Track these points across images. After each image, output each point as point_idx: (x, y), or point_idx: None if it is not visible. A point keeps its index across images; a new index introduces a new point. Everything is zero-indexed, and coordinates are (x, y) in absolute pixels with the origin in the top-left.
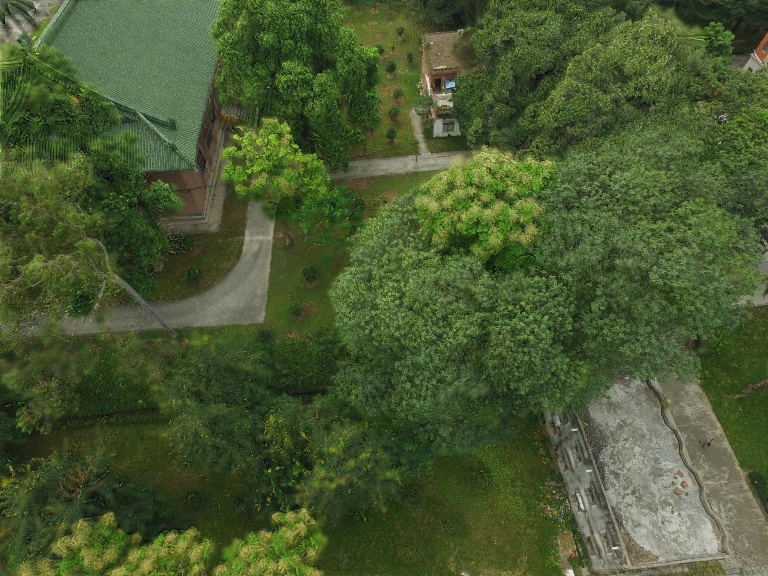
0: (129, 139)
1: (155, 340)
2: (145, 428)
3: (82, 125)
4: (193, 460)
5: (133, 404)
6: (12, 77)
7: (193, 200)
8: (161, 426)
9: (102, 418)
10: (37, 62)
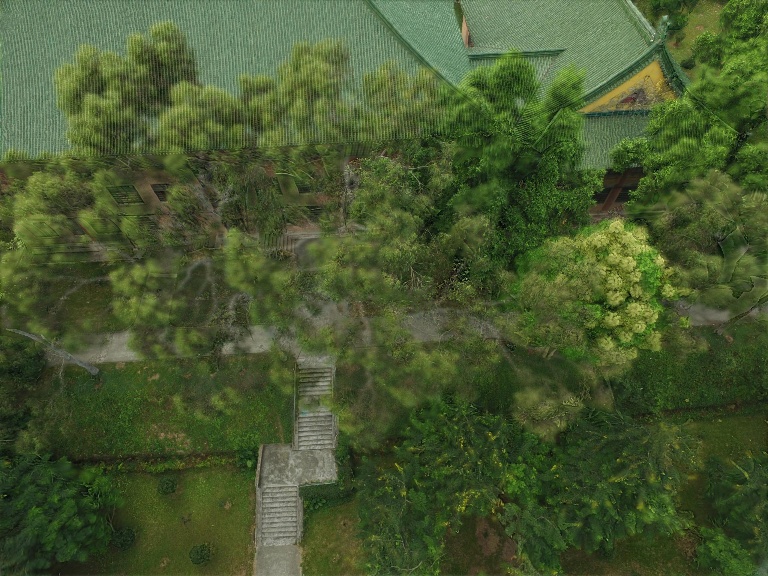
0: (684, 130)
1: (698, 338)
2: (687, 428)
3: (637, 116)
4: (762, 461)
5: (680, 403)
6: (525, 66)
7: (672, 194)
8: (705, 426)
9: (645, 417)
10: (664, 49)
